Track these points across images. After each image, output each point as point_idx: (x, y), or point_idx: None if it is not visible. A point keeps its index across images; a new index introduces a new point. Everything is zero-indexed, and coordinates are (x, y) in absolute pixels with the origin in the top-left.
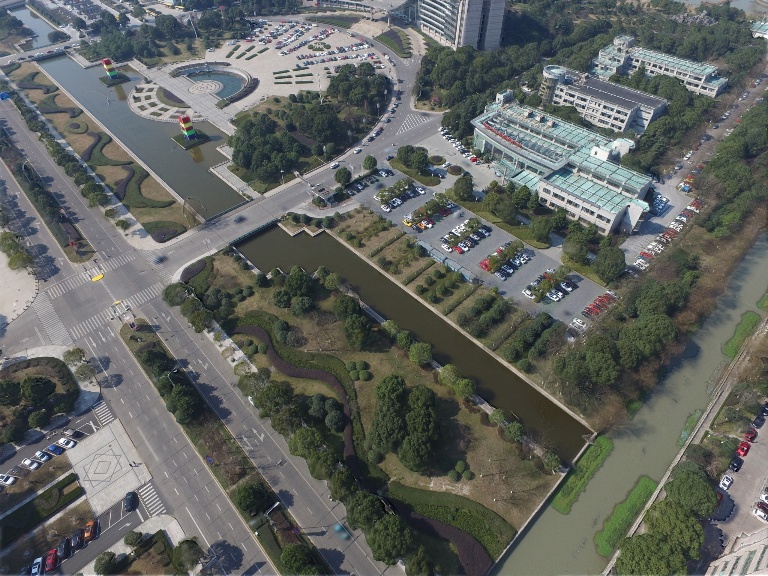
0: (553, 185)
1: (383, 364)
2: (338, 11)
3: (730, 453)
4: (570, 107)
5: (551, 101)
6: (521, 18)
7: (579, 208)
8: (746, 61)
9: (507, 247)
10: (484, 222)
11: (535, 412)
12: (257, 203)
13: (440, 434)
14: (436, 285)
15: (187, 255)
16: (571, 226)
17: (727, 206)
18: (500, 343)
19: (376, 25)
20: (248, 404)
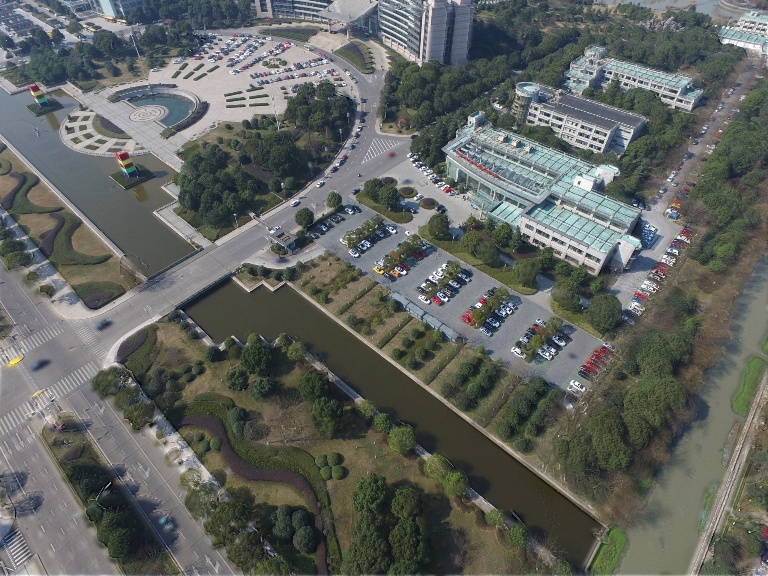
0: (536, 221)
1: (359, 454)
2: (294, 23)
3: (762, 549)
4: (546, 128)
5: (525, 120)
6: (487, 28)
7: (566, 246)
8: (719, 70)
9: (491, 297)
10: (463, 265)
11: (537, 504)
12: (208, 253)
13: (430, 550)
14: (415, 347)
15: (126, 324)
16: (559, 268)
17: (720, 236)
18: (491, 417)
19: (335, 38)
20: (199, 521)
